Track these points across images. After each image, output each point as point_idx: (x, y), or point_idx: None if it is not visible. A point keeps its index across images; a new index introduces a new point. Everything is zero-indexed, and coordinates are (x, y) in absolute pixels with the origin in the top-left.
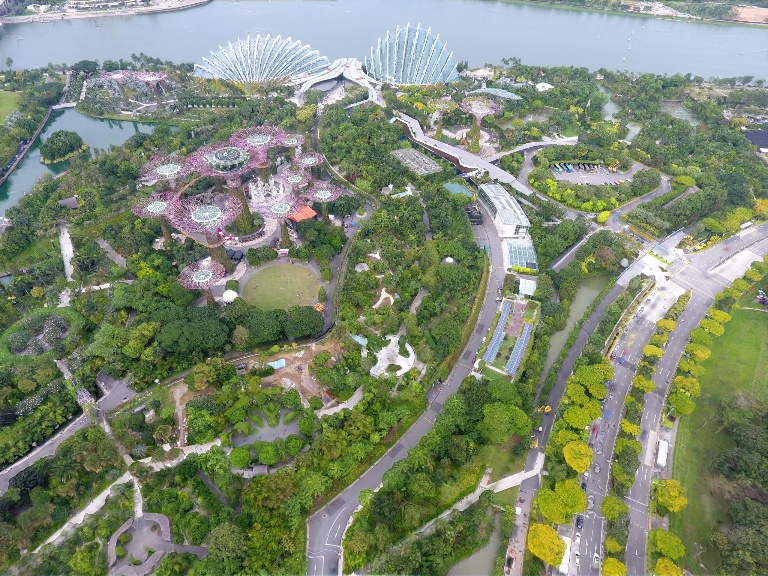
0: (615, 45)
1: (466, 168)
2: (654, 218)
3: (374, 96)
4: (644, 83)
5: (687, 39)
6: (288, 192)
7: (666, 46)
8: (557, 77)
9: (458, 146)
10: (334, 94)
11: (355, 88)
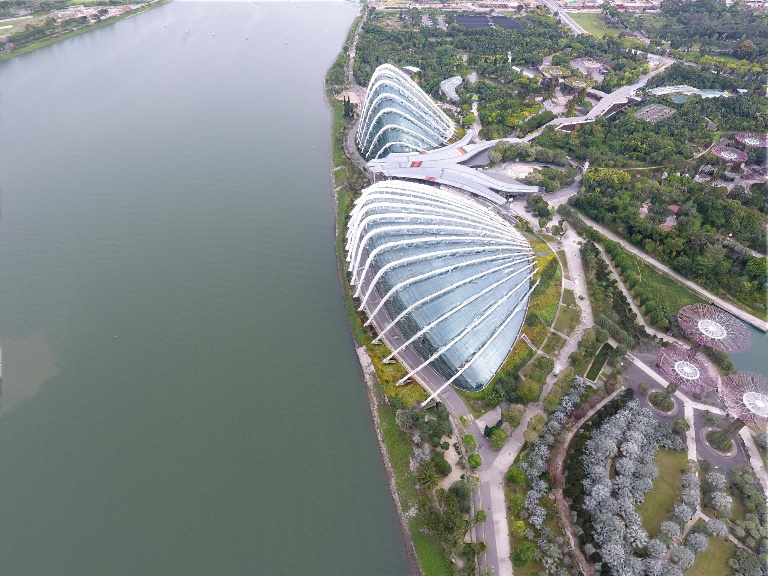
0: (227, 42)
1: (630, 101)
2: (644, 54)
3: (515, 139)
4: (400, 35)
5: (214, 18)
6: (755, 181)
7: (237, 26)
8: (391, 60)
9: (578, 108)
10: (507, 174)
11: (503, 150)
